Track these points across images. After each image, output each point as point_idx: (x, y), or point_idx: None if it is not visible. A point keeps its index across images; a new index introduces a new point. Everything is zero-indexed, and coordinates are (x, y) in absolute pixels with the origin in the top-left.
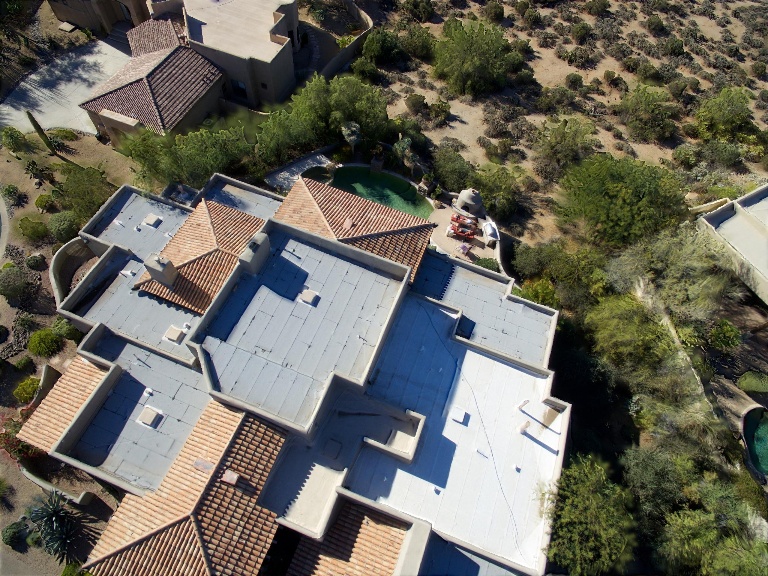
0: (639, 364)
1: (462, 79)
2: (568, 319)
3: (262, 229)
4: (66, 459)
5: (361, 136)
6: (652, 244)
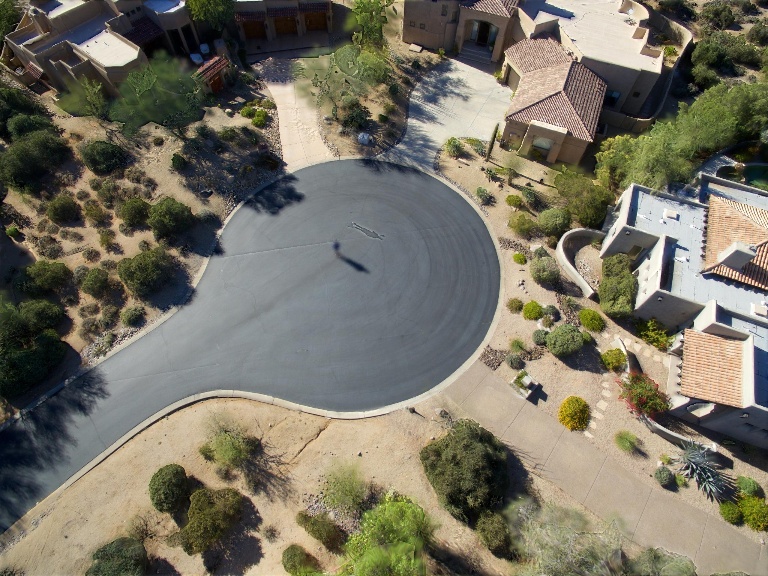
0: None
1: None
2: None
3: None
4: (767, 409)
5: None
6: None
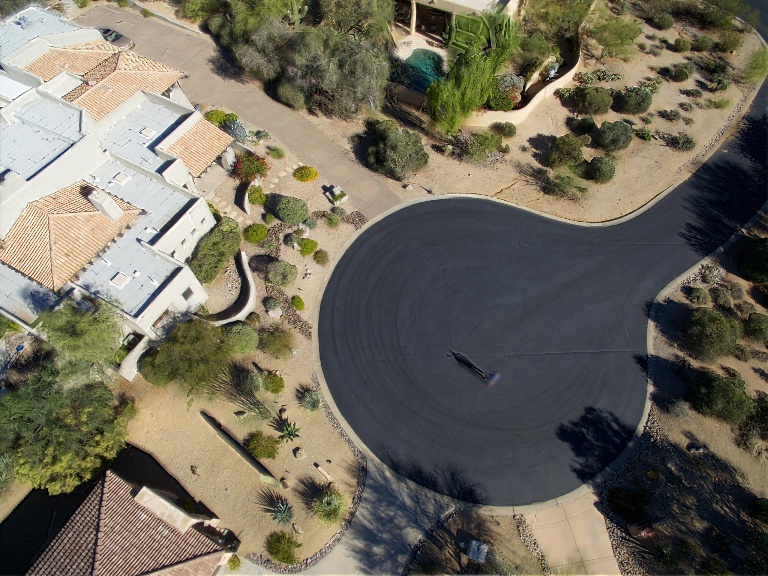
0: None
1: None
2: None
3: None
4: (190, 108)
5: None
6: None
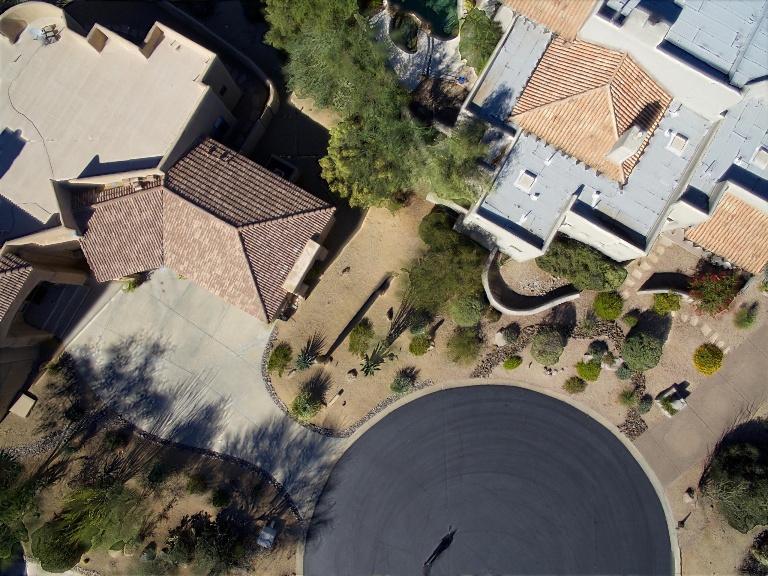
0: None
1: None
2: None
3: (610, 23)
4: None
5: None
6: None
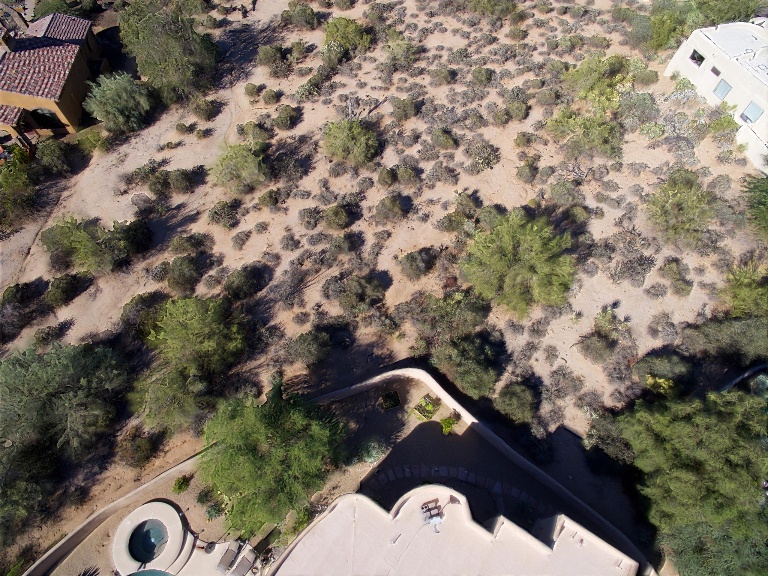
0: None
1: None
2: None
3: None
4: None
5: None
6: None
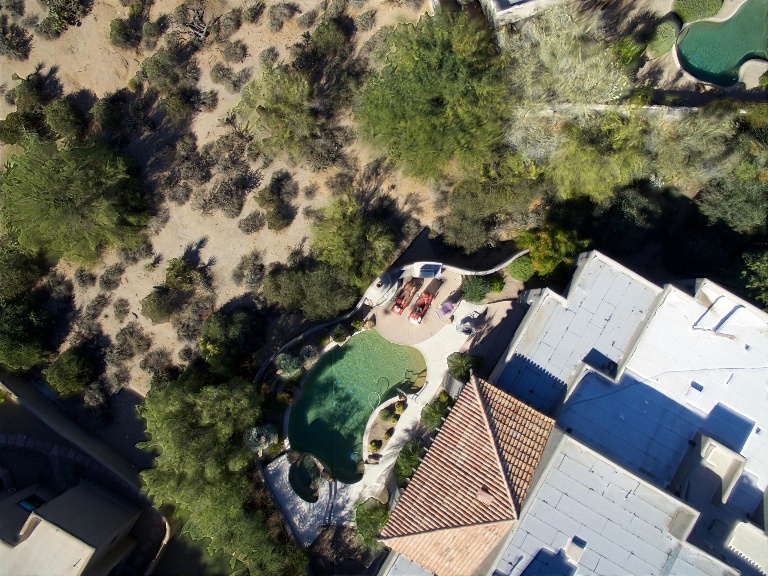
0: (630, 164)
1: (118, 226)
2: (555, 215)
3: None
4: None
5: (261, 421)
6: (523, 98)
